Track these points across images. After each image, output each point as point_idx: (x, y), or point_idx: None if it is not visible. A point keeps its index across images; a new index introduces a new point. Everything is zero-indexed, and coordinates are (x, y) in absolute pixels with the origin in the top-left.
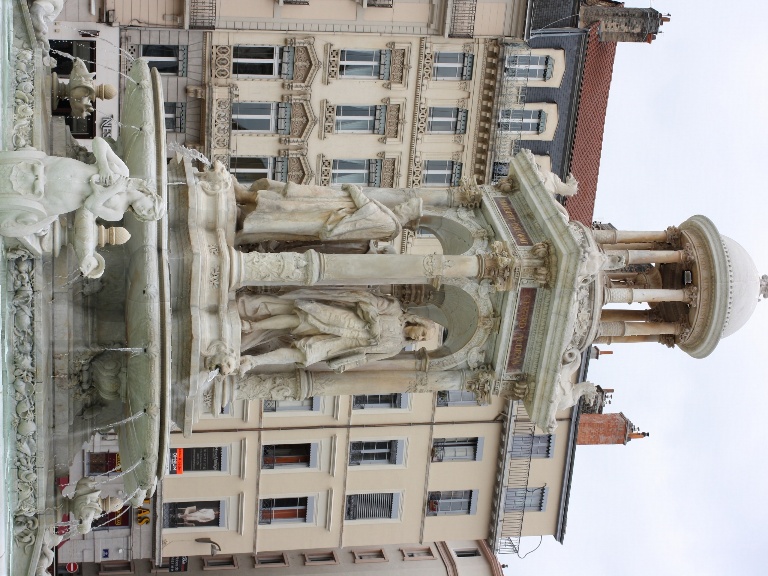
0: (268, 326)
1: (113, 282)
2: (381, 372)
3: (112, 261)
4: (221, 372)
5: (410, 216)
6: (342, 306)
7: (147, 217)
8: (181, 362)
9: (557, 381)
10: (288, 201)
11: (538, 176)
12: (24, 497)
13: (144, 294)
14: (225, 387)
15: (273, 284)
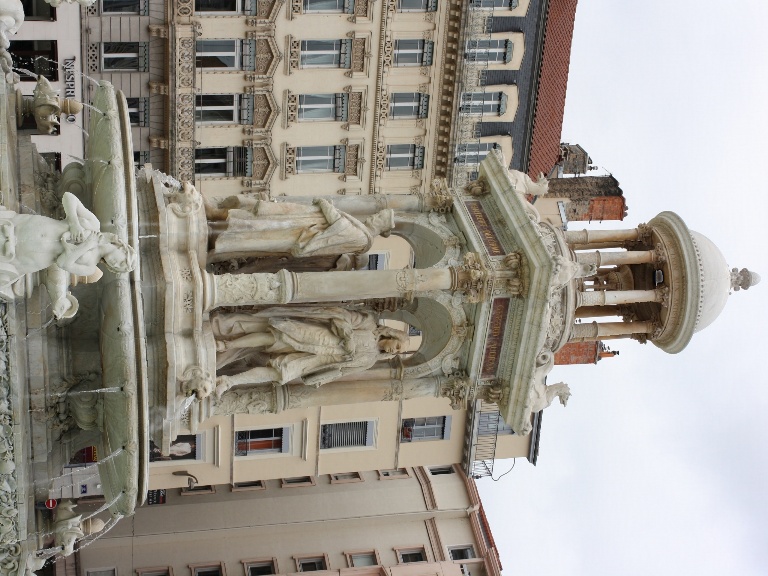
0: (243, 345)
1: (86, 312)
2: (356, 382)
3: (85, 292)
4: (198, 397)
5: (382, 228)
6: (316, 322)
7: (120, 269)
8: (157, 387)
9: (531, 387)
10: (259, 220)
11: (509, 180)
12: (6, 531)
13: (118, 331)
14: (202, 405)
15: (247, 304)
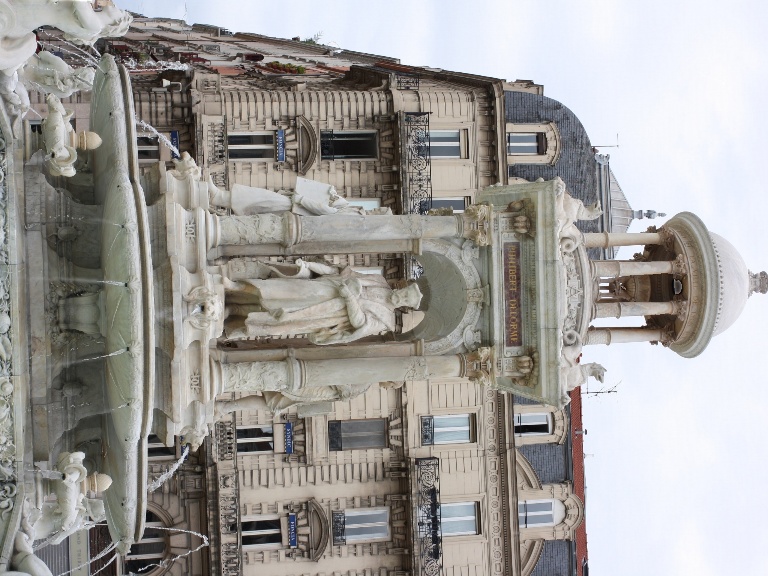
0: None
1: None
2: None
3: None
4: None
5: None
6: None
7: None
8: None
9: None
10: (279, 328)
11: (556, 248)
12: None
13: (122, 506)
14: None
15: None
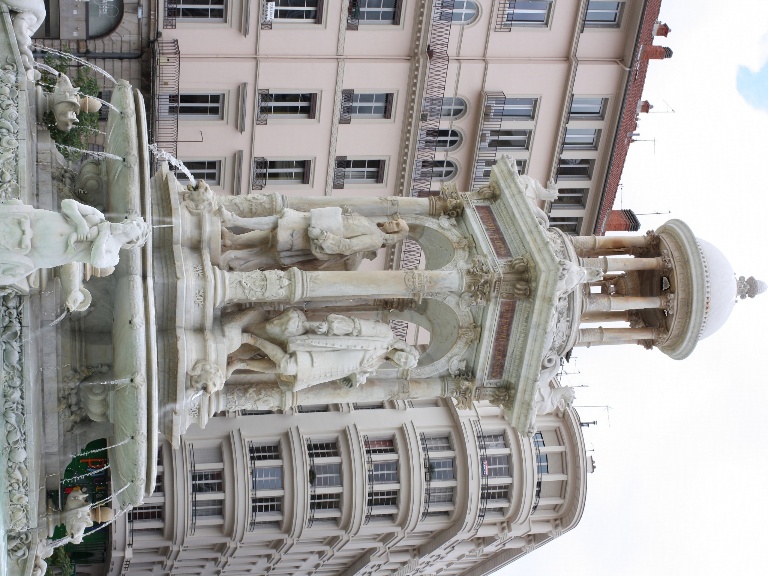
0: (247, 235)
1: None
2: None
3: None
4: None
5: None
6: None
7: None
8: (161, 200)
9: None
10: None
11: None
12: (5, 156)
13: None
14: None
15: None
